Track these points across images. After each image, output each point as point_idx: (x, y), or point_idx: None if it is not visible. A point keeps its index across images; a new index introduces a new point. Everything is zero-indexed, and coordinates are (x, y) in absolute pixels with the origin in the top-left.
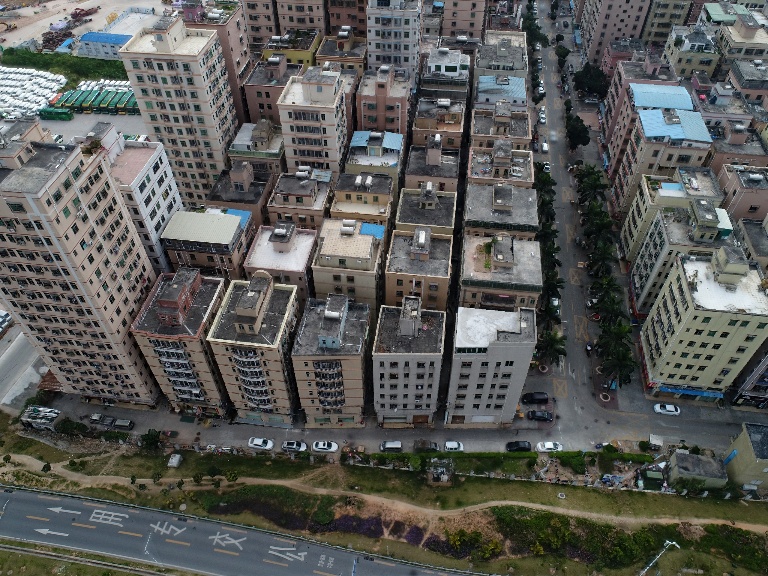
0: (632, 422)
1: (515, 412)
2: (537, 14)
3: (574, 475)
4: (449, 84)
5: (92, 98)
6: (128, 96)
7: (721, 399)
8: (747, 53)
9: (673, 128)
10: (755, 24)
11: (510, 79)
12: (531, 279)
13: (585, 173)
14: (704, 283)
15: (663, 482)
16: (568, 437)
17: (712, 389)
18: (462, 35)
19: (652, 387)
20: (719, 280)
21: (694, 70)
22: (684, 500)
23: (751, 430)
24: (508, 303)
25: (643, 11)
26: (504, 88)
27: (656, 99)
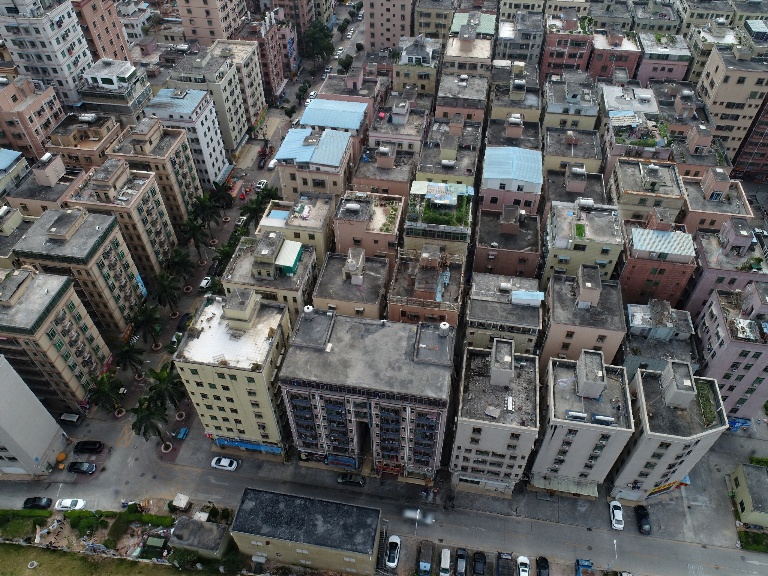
0: (180, 477)
1: (38, 464)
2: (362, 21)
3: (78, 538)
4: (108, 97)
5: None
6: None
7: (286, 453)
8: (461, 67)
9: (305, 150)
10: (471, 36)
11: (188, 92)
12: (23, 320)
13: (262, 195)
14: (212, 329)
15: (163, 550)
16: (100, 493)
17: (269, 443)
18: (189, 44)
19: (212, 438)
20: (230, 325)
21: (406, 85)
22: (172, 573)
23: (248, 496)
24: (13, 345)
25: (406, 20)
26: (174, 102)
27: (324, 117)
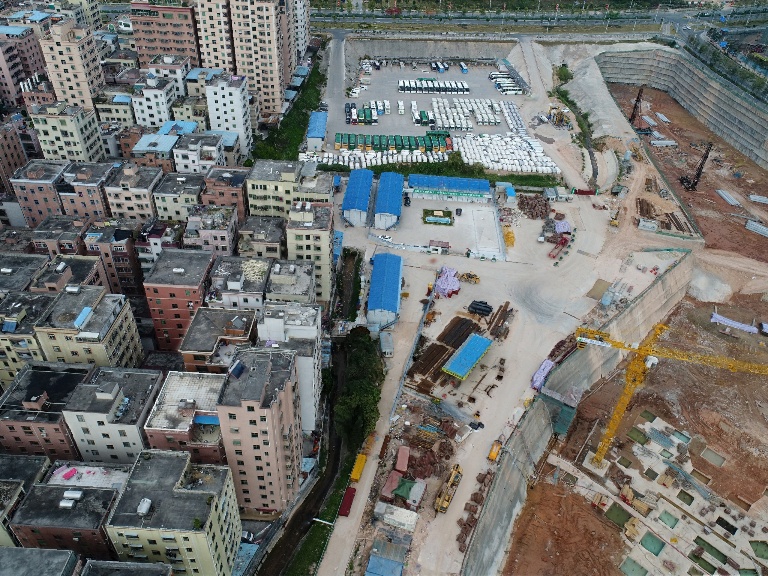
0: None
1: None
2: None
3: None
4: None
5: (419, 140)
6: (390, 140)
7: None
8: None
9: (34, 13)
10: None
11: None
12: None
13: None
14: None
15: None
16: None
17: None
18: None
19: None
20: None
21: None
22: None
23: None
24: None
25: None
26: None
27: (17, 27)
